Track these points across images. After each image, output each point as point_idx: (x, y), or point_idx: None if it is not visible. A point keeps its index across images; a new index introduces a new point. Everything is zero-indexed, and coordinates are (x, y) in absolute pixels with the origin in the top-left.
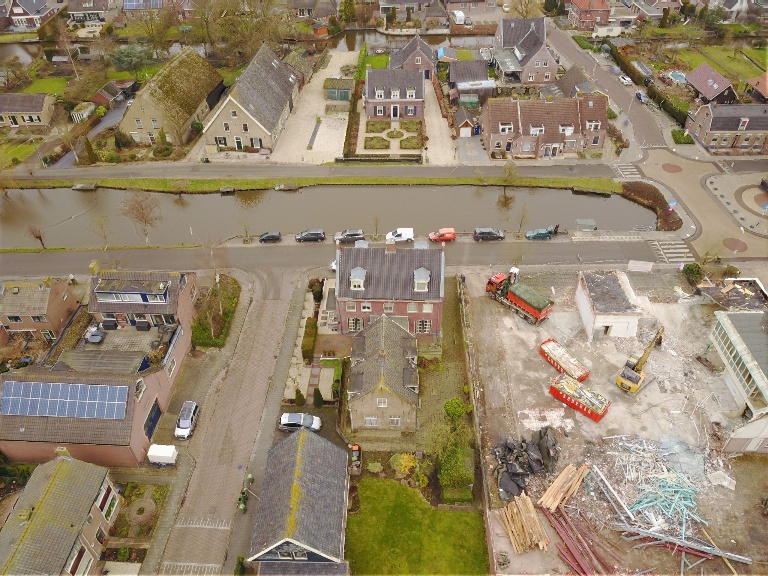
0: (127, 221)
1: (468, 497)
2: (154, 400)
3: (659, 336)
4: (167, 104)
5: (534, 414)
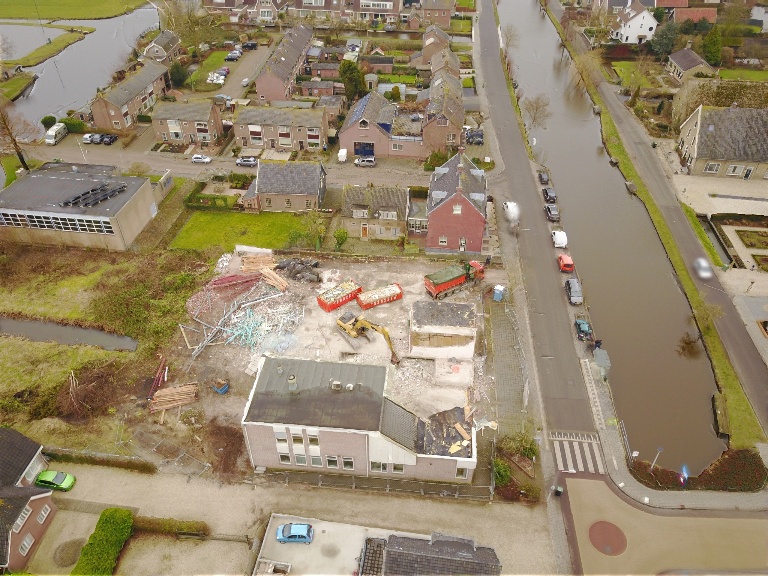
0: (566, 133)
1: (285, 247)
2: (371, 142)
3: (393, 351)
4: (704, 100)
5: (335, 277)
